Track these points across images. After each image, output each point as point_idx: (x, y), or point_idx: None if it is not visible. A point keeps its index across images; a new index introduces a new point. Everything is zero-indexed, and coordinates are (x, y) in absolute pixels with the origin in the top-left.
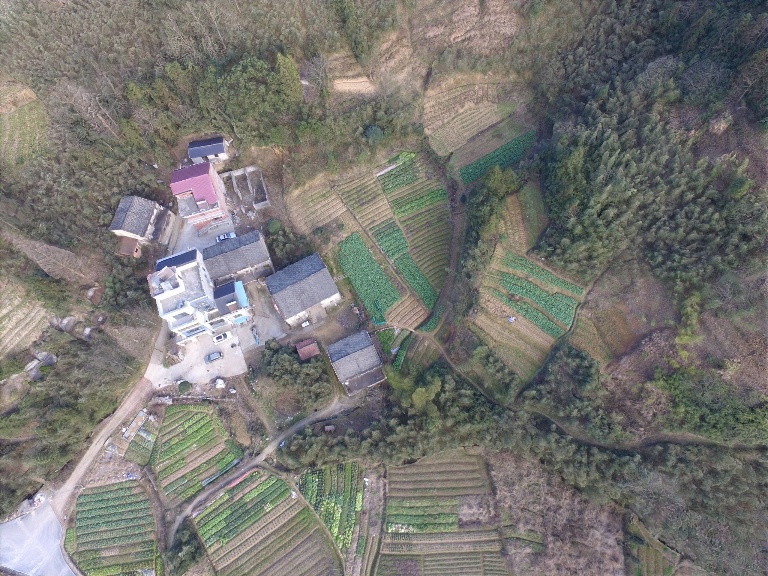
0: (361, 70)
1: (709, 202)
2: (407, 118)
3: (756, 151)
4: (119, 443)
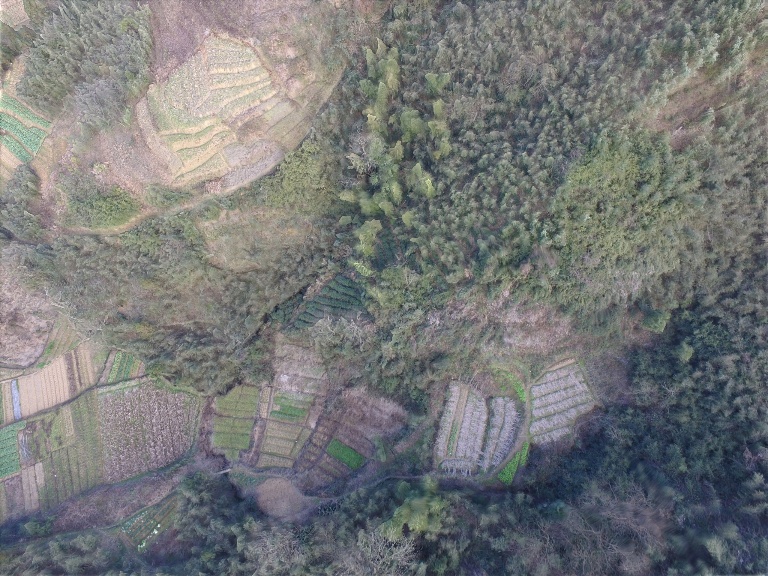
0: None
1: None
2: None
3: (163, 1)
4: None
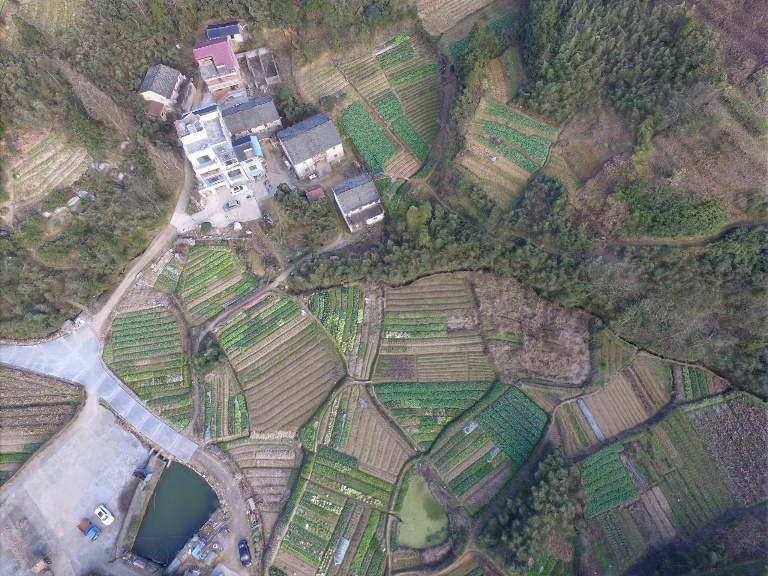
0: None
1: (662, 44)
2: (402, 3)
3: (703, 0)
4: (149, 276)
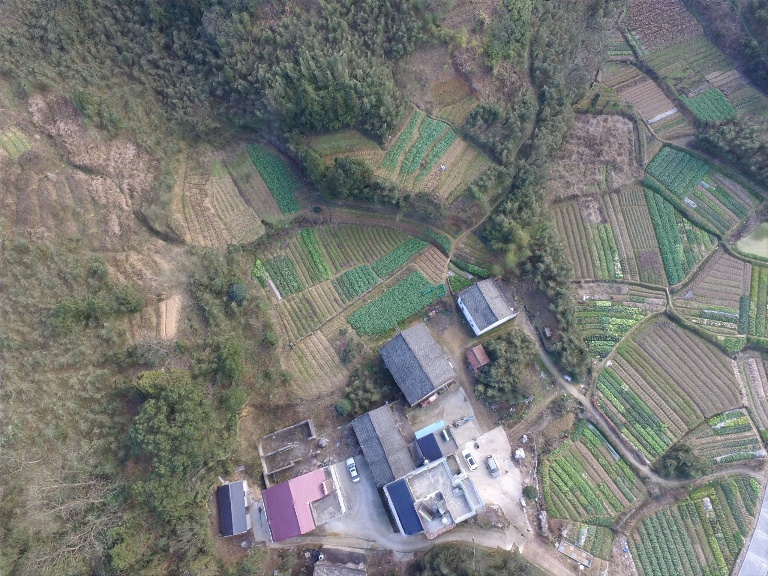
0: (150, 308)
1: (354, 6)
2: None
3: None
4: (596, 570)
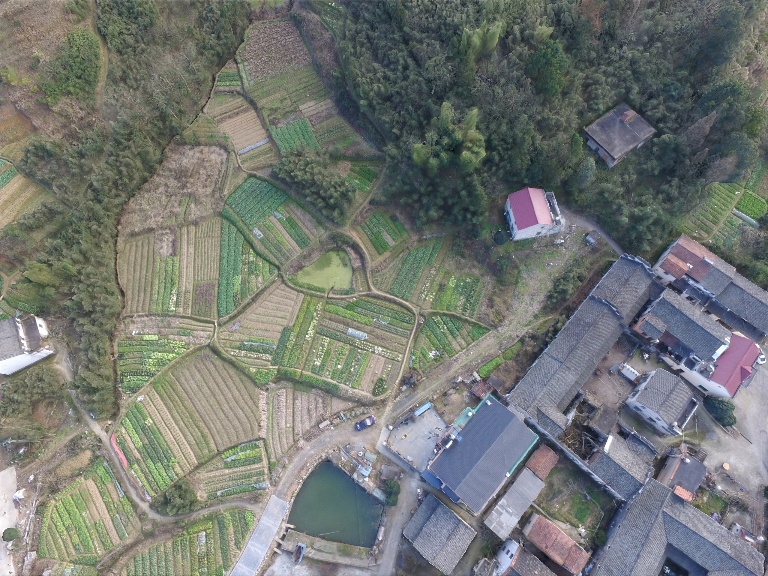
0: None
1: None
2: None
3: None
4: None
